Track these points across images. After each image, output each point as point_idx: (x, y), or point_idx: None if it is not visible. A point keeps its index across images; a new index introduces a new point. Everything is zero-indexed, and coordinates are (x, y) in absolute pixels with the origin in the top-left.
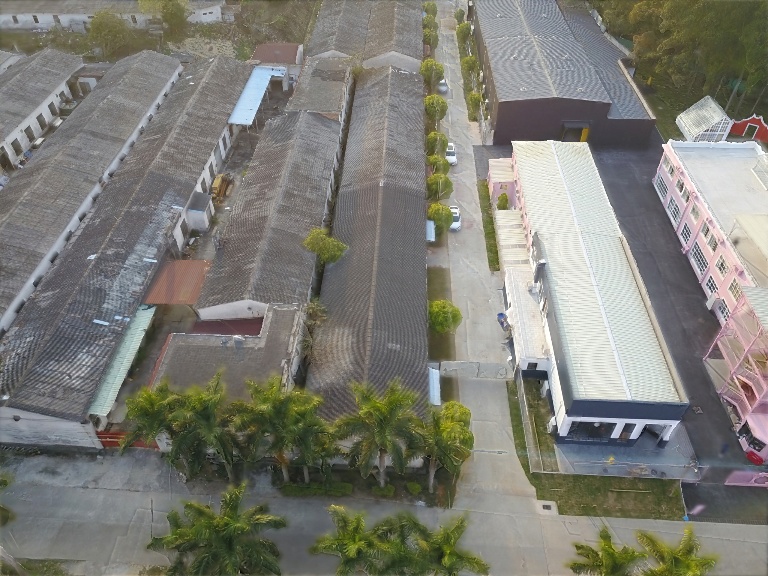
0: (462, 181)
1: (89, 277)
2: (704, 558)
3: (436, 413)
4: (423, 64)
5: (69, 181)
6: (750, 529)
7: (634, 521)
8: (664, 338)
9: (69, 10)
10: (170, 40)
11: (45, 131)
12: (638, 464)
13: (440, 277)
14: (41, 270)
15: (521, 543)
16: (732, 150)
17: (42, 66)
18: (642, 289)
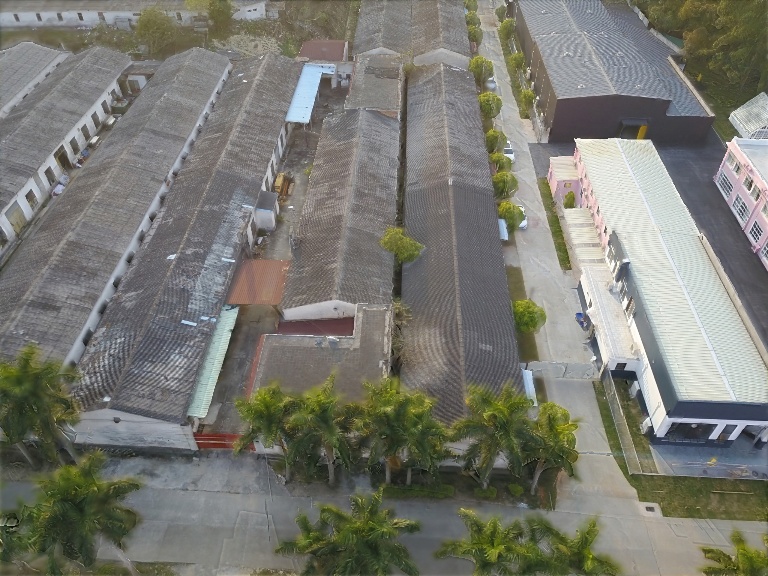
0: (522, 179)
1: (172, 277)
2: None
3: (533, 414)
4: (473, 61)
5: (137, 180)
6: None
7: (740, 523)
8: (760, 338)
9: (114, 7)
10: (215, 37)
11: (99, 129)
12: (742, 466)
13: (512, 276)
14: (119, 270)
15: (629, 545)
16: None
17: (93, 64)
18: (730, 289)
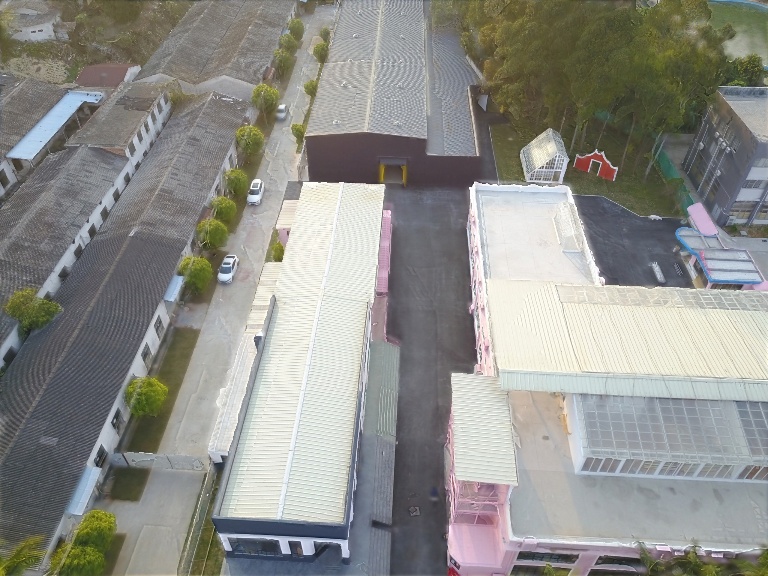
0: (259, 223)
1: None
2: None
3: None
4: (254, 90)
5: None
6: None
7: None
8: (354, 435)
9: None
10: None
11: None
12: None
13: (185, 340)
14: None
15: None
16: (542, 195)
17: None
18: None
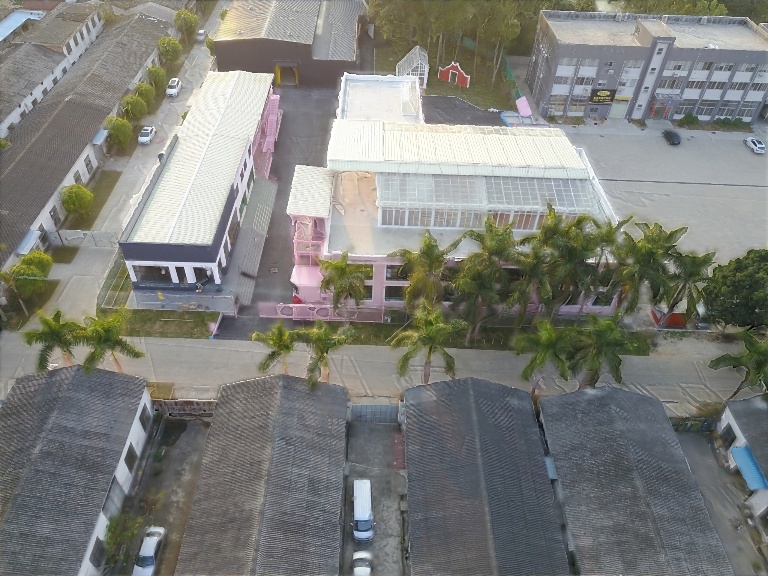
0: (175, 109)
1: None
2: (208, 361)
3: None
4: (176, 14)
5: None
6: None
7: (167, 339)
8: (225, 204)
9: None
10: None
11: None
12: (176, 296)
13: (110, 177)
14: None
15: None
16: (396, 82)
17: None
18: None
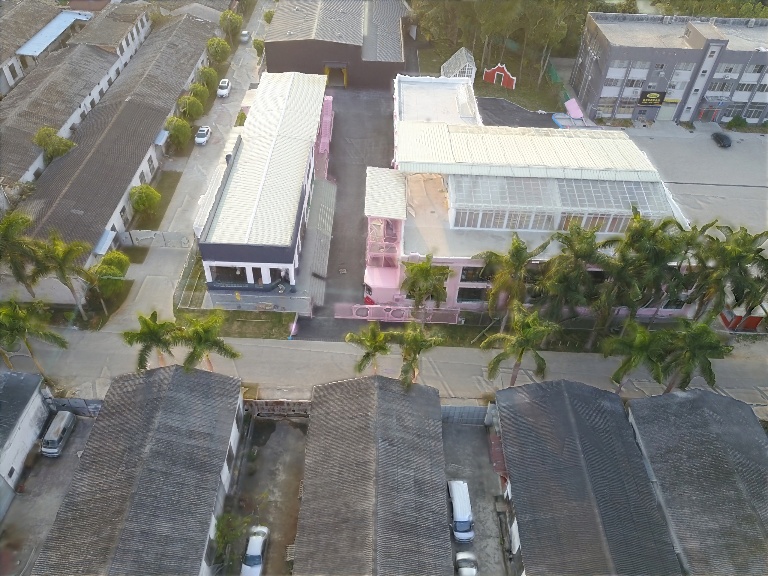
0: (227, 109)
1: None
2: (289, 362)
3: None
4: (221, 15)
5: None
6: (337, 345)
7: (246, 340)
8: (298, 205)
9: None
10: None
11: None
12: (254, 296)
13: (171, 178)
14: None
15: None
16: (449, 84)
17: None
18: None
